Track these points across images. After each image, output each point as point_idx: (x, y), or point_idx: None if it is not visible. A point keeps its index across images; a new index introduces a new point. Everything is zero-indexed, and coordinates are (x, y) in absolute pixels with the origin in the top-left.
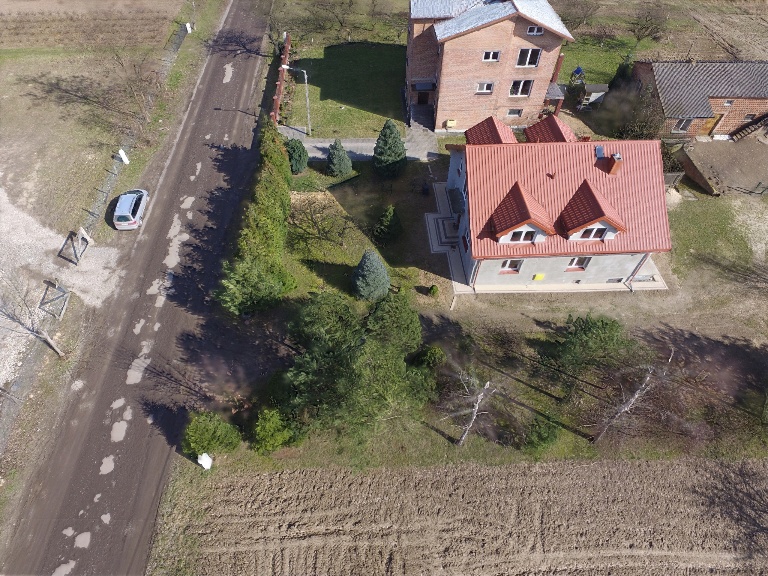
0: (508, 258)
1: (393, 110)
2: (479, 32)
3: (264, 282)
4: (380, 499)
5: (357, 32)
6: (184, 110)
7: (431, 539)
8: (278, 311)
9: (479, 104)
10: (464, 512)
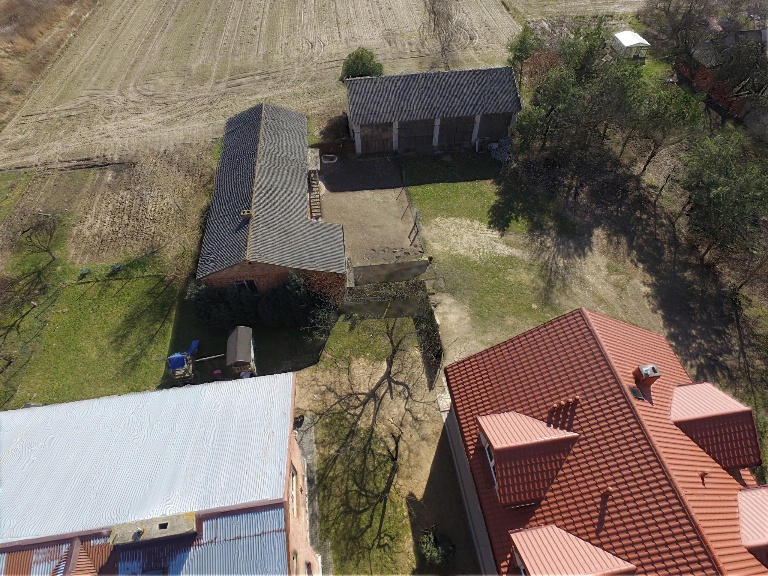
0: None
1: None
2: None
3: None
4: None
5: None
6: None
7: None
8: None
9: None
10: None
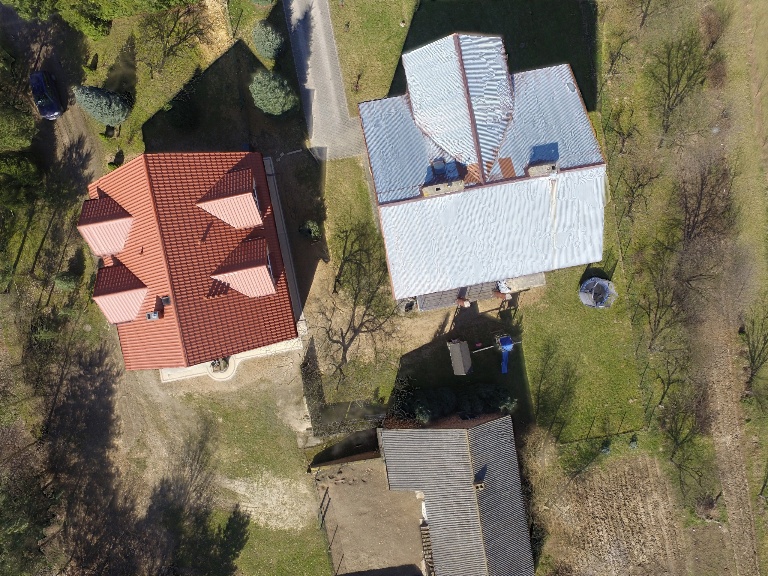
0: None
1: None
2: None
3: (19, 1)
4: None
5: (633, 3)
6: None
7: None
8: (71, 32)
9: None
10: None
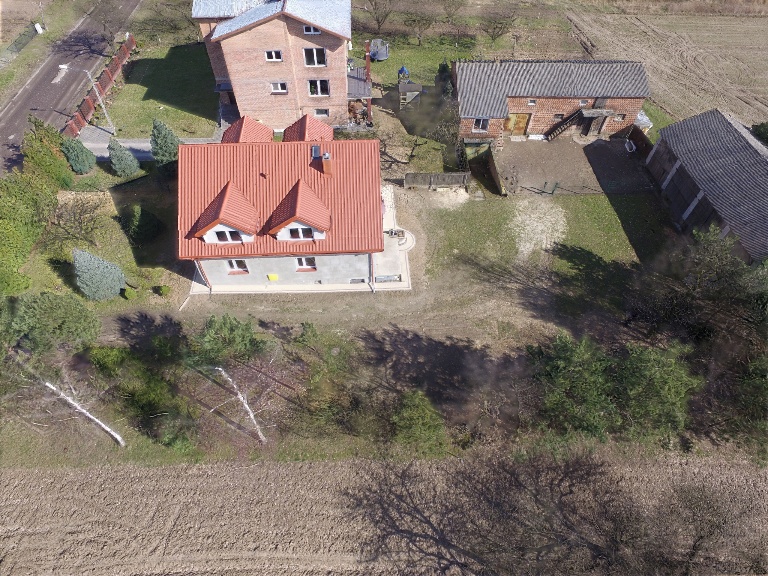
0: (223, 258)
1: (211, 110)
2: (251, 32)
3: None
4: (19, 501)
5: None
6: (0, 110)
7: (53, 541)
8: None
9: (279, 104)
10: (99, 514)
